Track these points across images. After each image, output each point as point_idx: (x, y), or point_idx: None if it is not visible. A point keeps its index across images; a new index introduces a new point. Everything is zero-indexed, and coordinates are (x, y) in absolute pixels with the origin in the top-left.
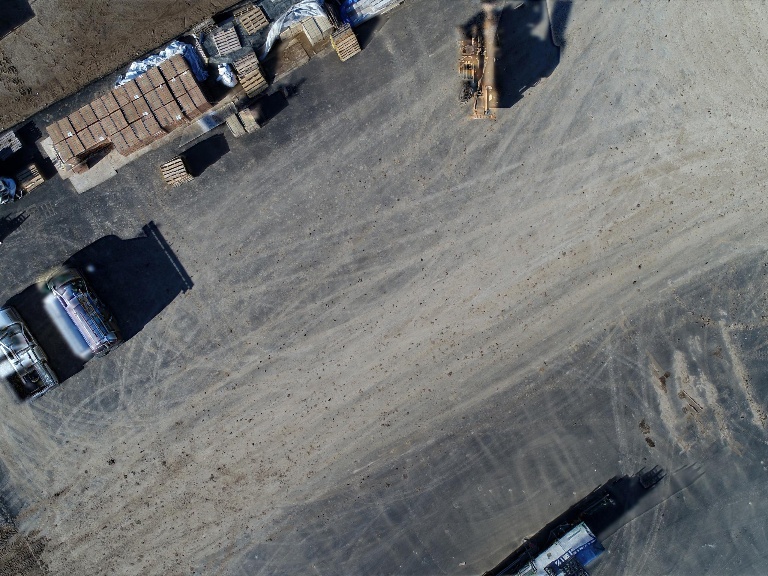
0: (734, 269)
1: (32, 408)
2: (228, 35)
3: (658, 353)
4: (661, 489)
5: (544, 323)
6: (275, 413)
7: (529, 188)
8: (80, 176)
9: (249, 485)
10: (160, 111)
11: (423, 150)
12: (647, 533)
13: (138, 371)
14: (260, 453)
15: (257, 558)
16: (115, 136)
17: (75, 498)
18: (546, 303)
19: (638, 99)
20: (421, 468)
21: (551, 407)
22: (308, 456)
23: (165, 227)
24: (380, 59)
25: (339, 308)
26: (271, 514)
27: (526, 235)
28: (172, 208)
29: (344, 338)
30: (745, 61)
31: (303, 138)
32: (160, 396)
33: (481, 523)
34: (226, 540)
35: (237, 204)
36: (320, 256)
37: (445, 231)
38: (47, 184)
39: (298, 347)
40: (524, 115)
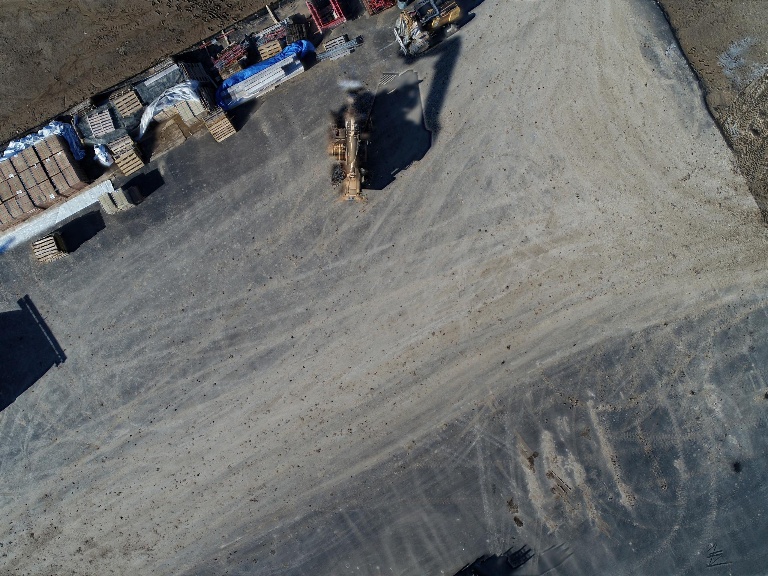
0: (602, 351)
1: None
2: (102, 117)
3: (526, 433)
4: (529, 569)
5: (413, 402)
6: (144, 487)
7: (399, 268)
8: None
9: (116, 558)
10: (34, 190)
11: (296, 230)
12: None
13: (9, 443)
14: (128, 527)
15: None
16: None
17: None
18: (415, 382)
19: (508, 183)
20: (289, 544)
21: (419, 485)
22: (176, 530)
23: (40, 301)
24: (255, 140)
25: (210, 384)
26: None
27: (396, 315)
28: (47, 282)
29: (214, 413)
30: (613, 148)
31: (178, 216)
32: (30, 468)
33: None
34: None
35: (111, 279)
36: (192, 332)
37: (316, 309)
38: None
39: (168, 421)
40: (396, 197)
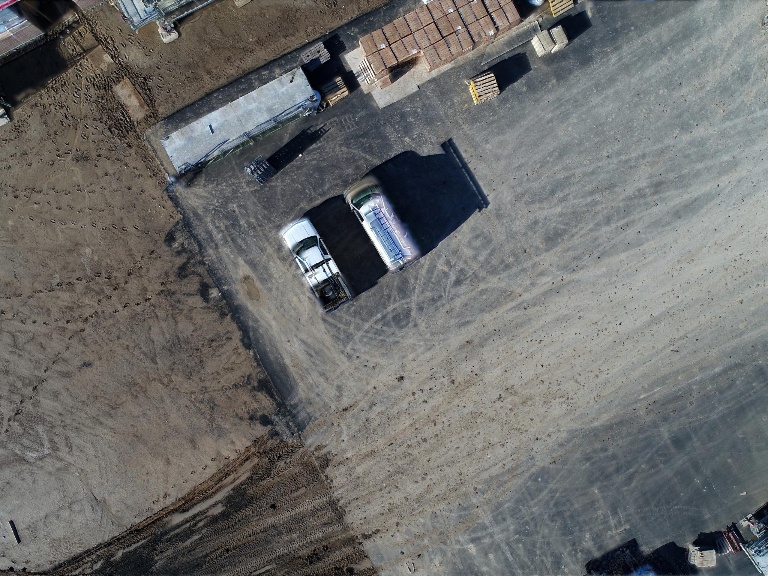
0: None
1: (324, 322)
2: None
3: None
4: None
5: None
6: (565, 335)
7: None
8: (382, 91)
9: (536, 407)
10: (474, 25)
11: (724, 76)
12: None
13: (431, 288)
14: (549, 375)
15: (540, 480)
16: (428, 49)
17: (363, 414)
18: None
19: None
20: (707, 395)
21: None
22: (596, 379)
23: (464, 145)
24: None
25: (634, 232)
26: (556, 436)
27: None
28: (472, 126)
29: (637, 262)
30: None
31: (605, 60)
32: (452, 314)
33: (764, 453)
34: (510, 461)
35: (536, 124)
36: (617, 179)
37: (743, 158)
38: (349, 98)
39: (591, 269)
40: None
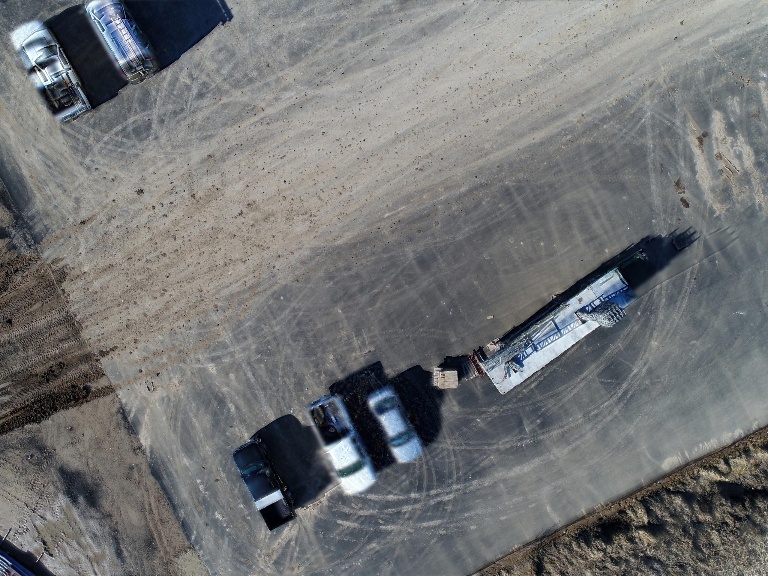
0: None
1: (63, 132)
2: None
3: (696, 112)
4: (694, 252)
5: (583, 74)
6: (308, 151)
7: None
8: None
9: (278, 223)
10: None
11: None
12: (678, 296)
13: (172, 101)
14: (291, 191)
15: (283, 299)
16: None
17: (101, 227)
18: (586, 54)
19: None
20: (453, 216)
21: (587, 161)
22: (340, 197)
23: None
24: None
25: (378, 48)
26: (299, 254)
27: None
28: None
29: (382, 78)
30: None
31: None
32: (193, 127)
33: (511, 276)
34: (252, 278)
35: None
36: None
37: None
38: None
39: (335, 85)
40: None
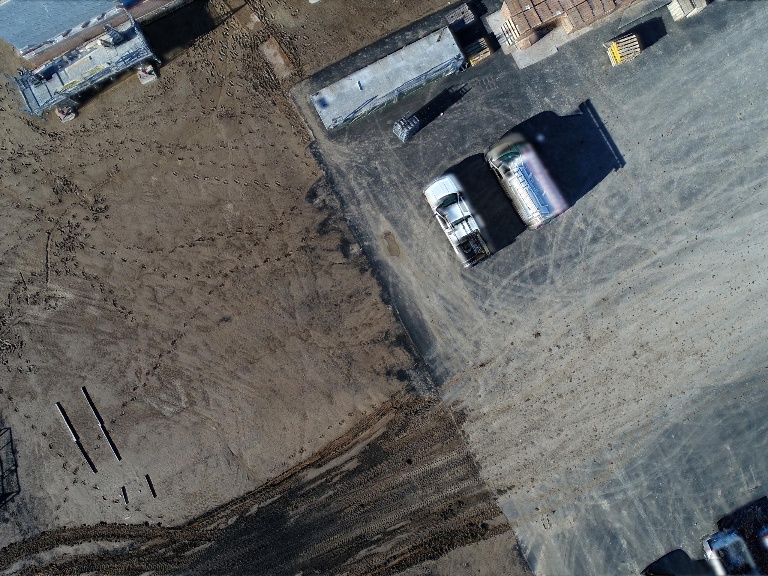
0: None
1: (463, 278)
2: None
3: None
4: None
5: None
6: (699, 293)
7: None
8: (522, 52)
9: (670, 364)
10: None
11: None
12: None
13: (568, 246)
14: (683, 332)
15: (674, 437)
16: (571, 11)
17: (500, 369)
18: None
19: None
20: None
21: None
22: (729, 337)
23: (601, 106)
24: None
25: (766, 192)
26: (690, 394)
27: None
28: (609, 87)
29: None
30: None
31: (738, 25)
32: (588, 272)
33: None
34: (645, 418)
35: (671, 86)
36: (749, 140)
37: None
38: (490, 58)
39: (724, 229)
40: None
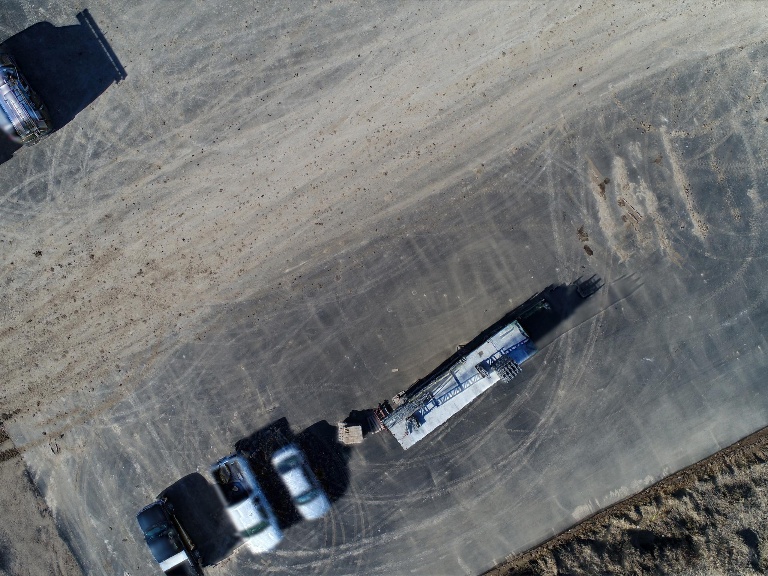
0: (676, 75)
1: None
2: None
3: (598, 159)
4: (599, 299)
5: (482, 124)
6: (207, 208)
7: None
8: None
9: (178, 282)
10: None
11: None
12: (584, 344)
13: (68, 161)
14: (190, 249)
15: (185, 357)
16: None
17: None
18: (485, 103)
19: None
20: (354, 270)
21: (488, 211)
22: (239, 253)
23: (99, 15)
24: None
25: (274, 103)
26: (200, 312)
27: (466, 34)
28: None
29: (279, 133)
30: None
31: None
32: (90, 188)
33: (415, 329)
34: (153, 338)
35: None
36: (256, 49)
37: (383, 27)
38: None
39: (232, 141)
40: None
